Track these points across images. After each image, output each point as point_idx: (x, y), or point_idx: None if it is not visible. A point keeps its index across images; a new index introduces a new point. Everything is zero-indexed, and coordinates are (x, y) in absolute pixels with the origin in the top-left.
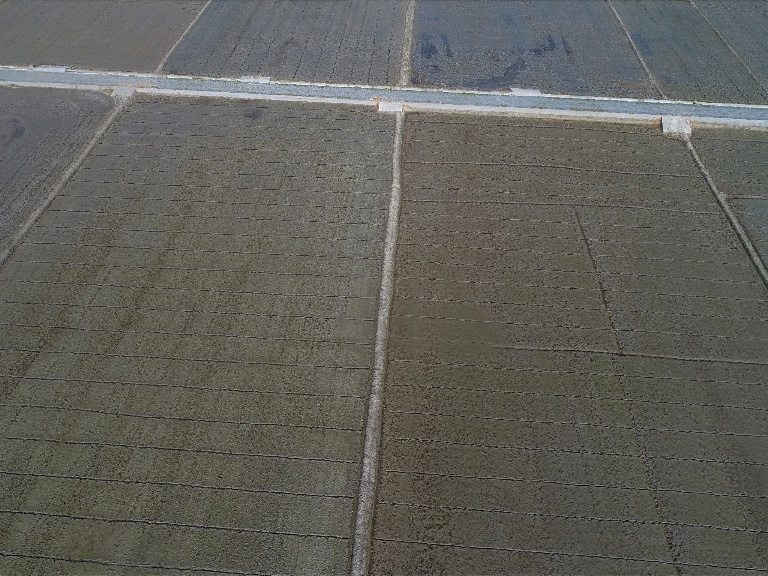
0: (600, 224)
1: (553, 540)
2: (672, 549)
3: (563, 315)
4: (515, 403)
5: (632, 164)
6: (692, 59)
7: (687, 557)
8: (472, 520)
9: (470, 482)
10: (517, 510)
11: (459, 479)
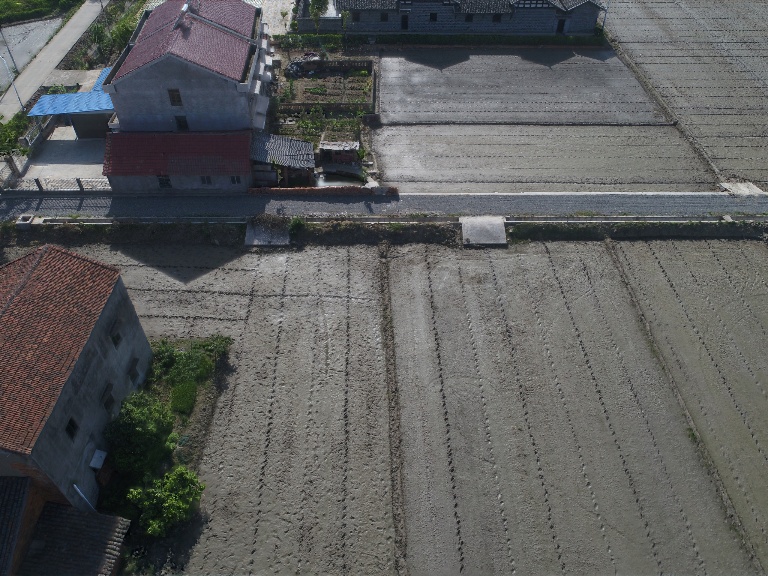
0: (766, 97)
1: (722, 4)
2: (679, 4)
3: (759, 53)
4: (761, 28)
5: (766, 145)
6: (760, 361)
7: (673, 3)
8: (755, 6)
9: (762, 12)
10: (739, 8)
11: (767, 12)
